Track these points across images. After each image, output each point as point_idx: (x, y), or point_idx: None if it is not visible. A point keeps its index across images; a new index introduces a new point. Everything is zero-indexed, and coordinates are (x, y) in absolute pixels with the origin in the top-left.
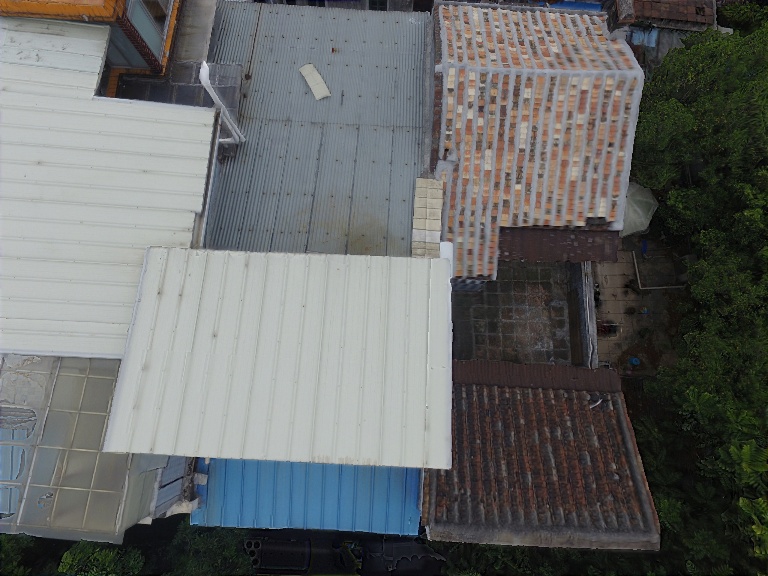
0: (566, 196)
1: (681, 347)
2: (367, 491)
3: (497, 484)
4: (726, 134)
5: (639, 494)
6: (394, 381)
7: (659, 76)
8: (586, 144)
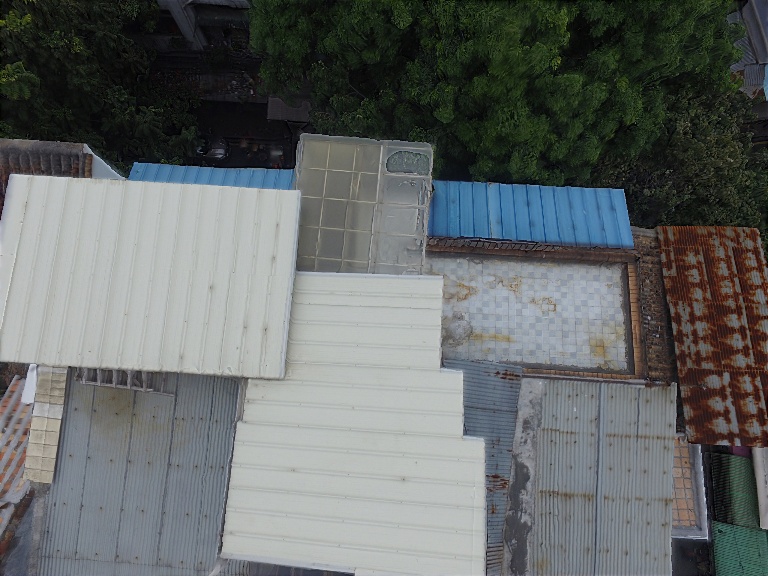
0: None
1: None
2: None
3: None
4: None
5: None
6: (48, 244)
7: None
8: None
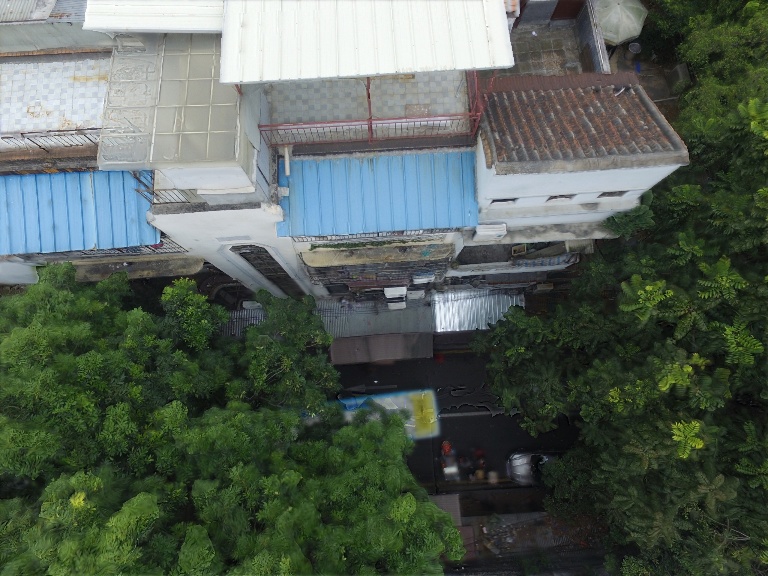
0: None
1: None
2: (429, 192)
3: (546, 140)
4: None
5: (667, 133)
6: (457, 13)
7: None
8: None
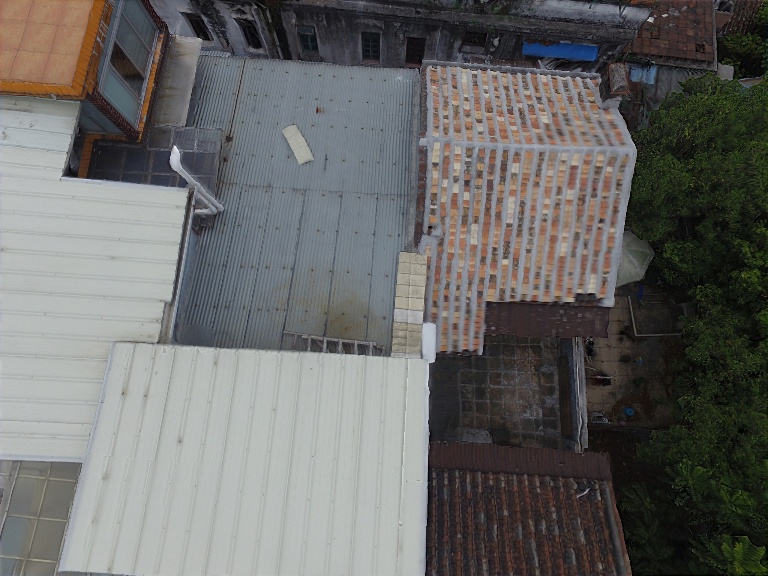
0: (555, 272)
1: (675, 407)
2: None
3: None
4: (723, 193)
5: None
6: (367, 495)
7: (656, 124)
8: (576, 220)
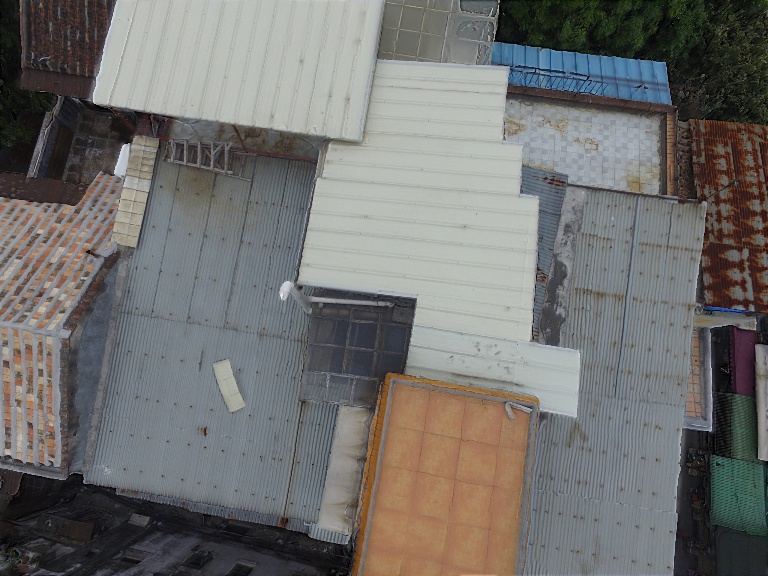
0: None
1: None
2: None
3: None
4: None
5: None
6: (160, 14)
7: None
8: None
